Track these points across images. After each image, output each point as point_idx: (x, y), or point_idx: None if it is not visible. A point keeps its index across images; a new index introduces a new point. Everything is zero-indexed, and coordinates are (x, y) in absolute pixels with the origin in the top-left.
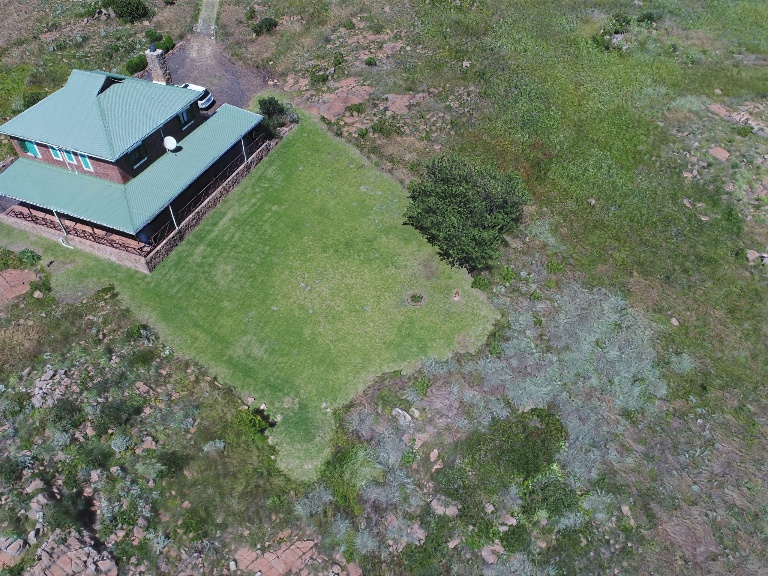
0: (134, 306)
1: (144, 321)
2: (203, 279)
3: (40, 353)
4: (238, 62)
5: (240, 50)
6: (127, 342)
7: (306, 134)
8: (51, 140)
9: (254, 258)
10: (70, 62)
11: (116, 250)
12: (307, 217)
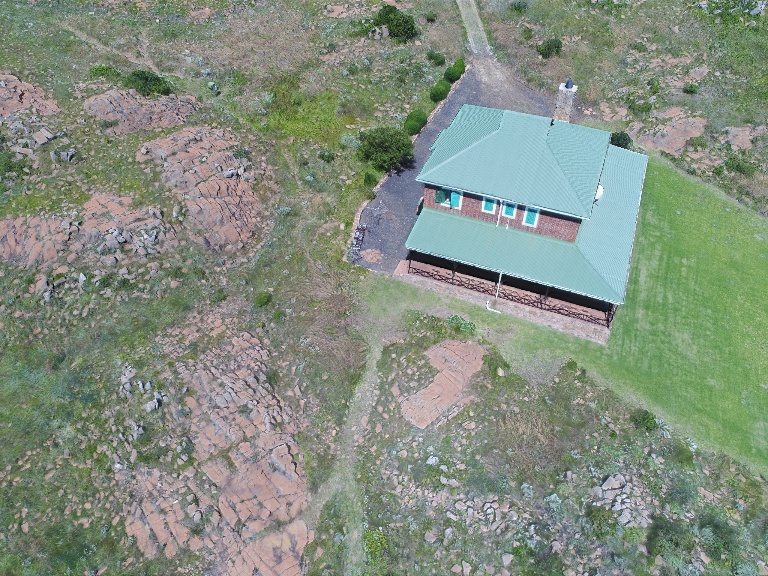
0: (612, 385)
1: (636, 404)
2: (667, 351)
3: (565, 451)
4: (538, 88)
5: (534, 74)
6: (644, 434)
7: (657, 172)
8: (498, 193)
9: (705, 324)
10: (368, 88)
11: (567, 318)
12: (725, 272)
